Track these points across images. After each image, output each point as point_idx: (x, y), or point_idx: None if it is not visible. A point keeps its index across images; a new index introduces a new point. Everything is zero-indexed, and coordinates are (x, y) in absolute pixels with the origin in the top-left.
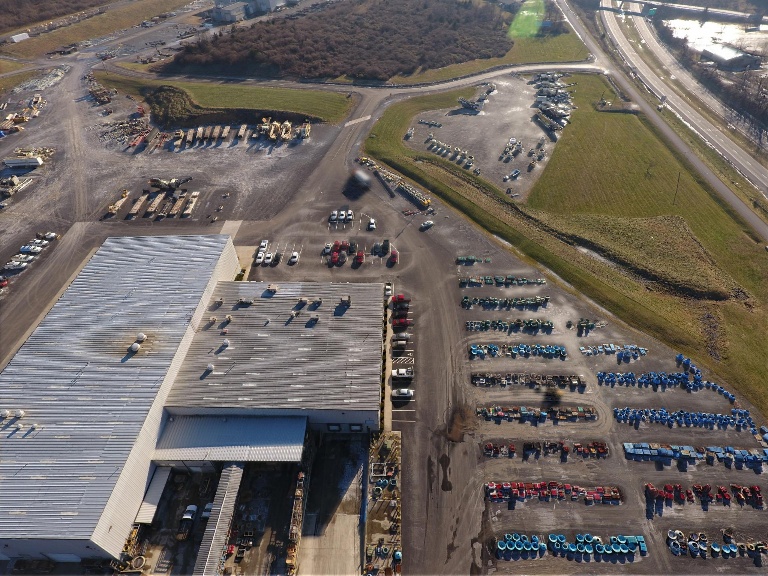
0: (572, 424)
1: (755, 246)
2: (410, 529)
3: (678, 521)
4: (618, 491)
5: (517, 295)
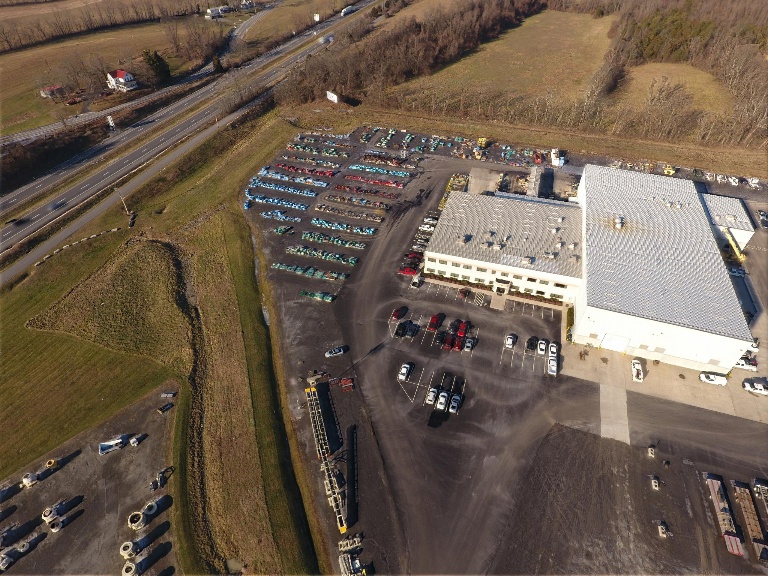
0: (343, 196)
1: (41, 269)
2: (445, 184)
3: (330, 169)
4: (345, 177)
5: (307, 259)
